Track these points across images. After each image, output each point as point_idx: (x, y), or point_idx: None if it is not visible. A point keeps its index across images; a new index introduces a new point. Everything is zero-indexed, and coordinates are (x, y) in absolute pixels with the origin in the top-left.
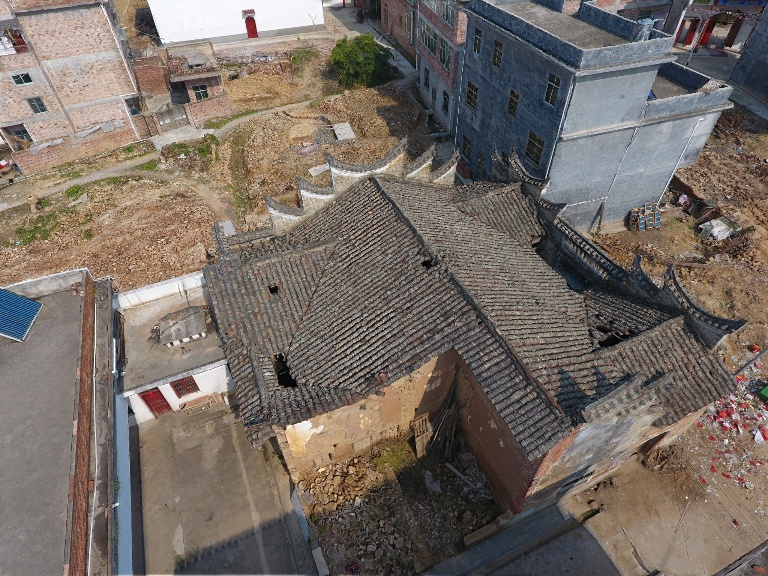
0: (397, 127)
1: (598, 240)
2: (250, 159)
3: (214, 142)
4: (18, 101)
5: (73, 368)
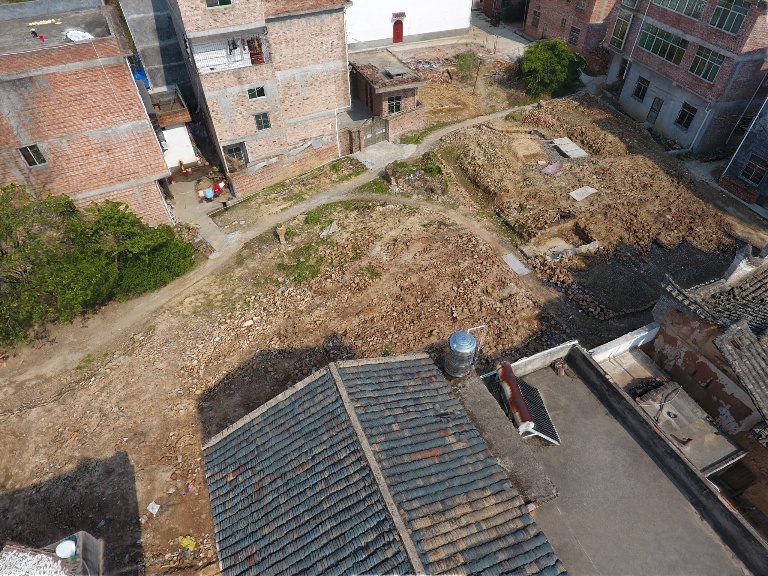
0: (634, 143)
1: None
2: (487, 180)
3: (435, 160)
4: (246, 117)
5: (661, 485)
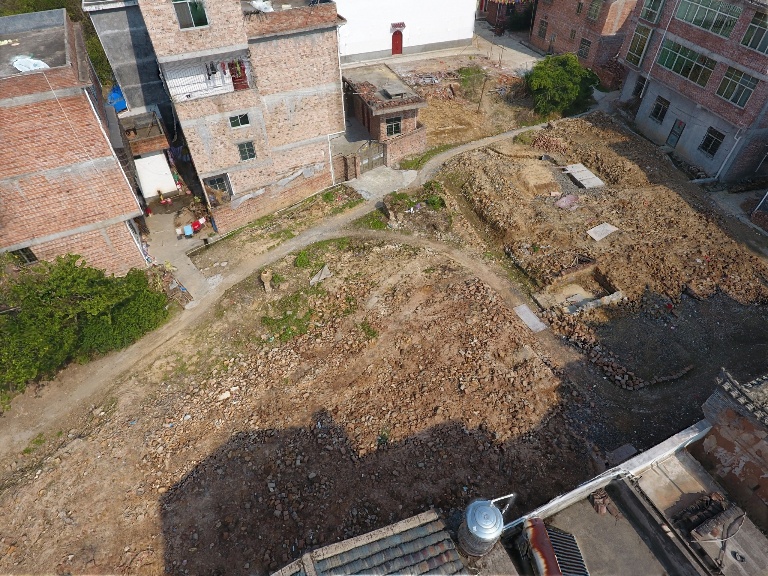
0: (654, 172)
1: None
2: (495, 214)
3: (438, 190)
4: (229, 147)
5: None
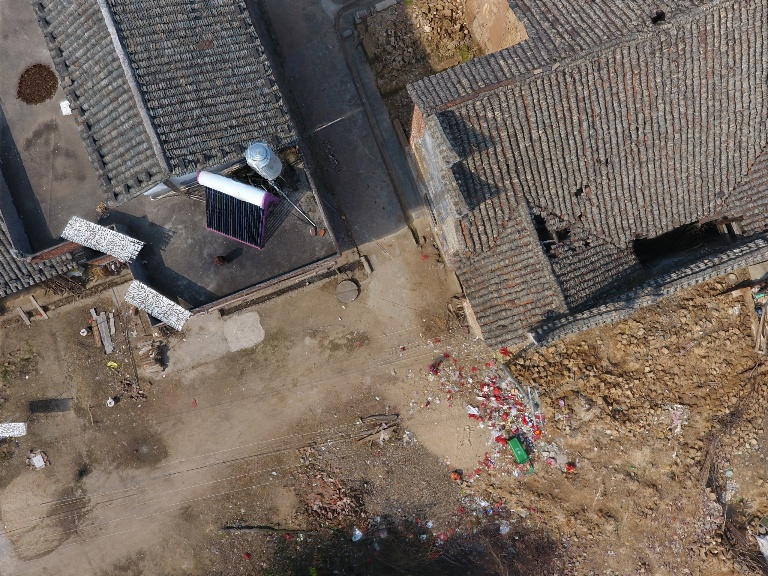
0: None
1: (766, 368)
2: None
3: None
4: None
5: None
